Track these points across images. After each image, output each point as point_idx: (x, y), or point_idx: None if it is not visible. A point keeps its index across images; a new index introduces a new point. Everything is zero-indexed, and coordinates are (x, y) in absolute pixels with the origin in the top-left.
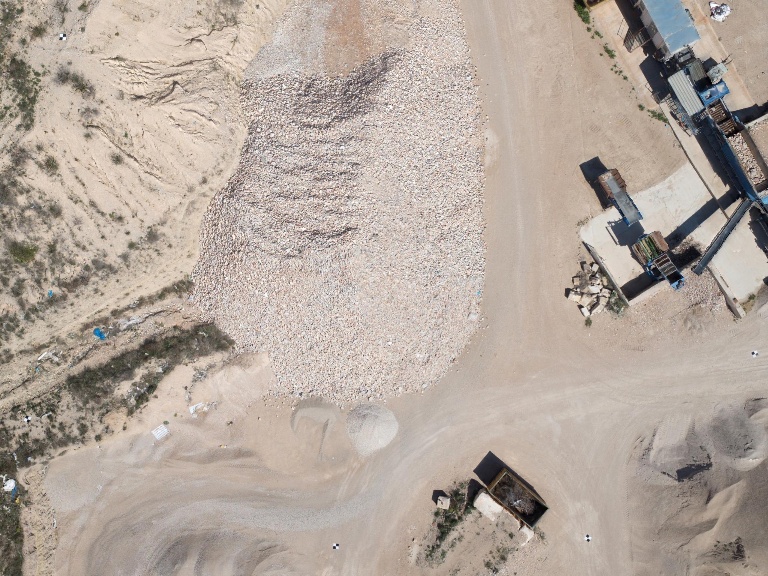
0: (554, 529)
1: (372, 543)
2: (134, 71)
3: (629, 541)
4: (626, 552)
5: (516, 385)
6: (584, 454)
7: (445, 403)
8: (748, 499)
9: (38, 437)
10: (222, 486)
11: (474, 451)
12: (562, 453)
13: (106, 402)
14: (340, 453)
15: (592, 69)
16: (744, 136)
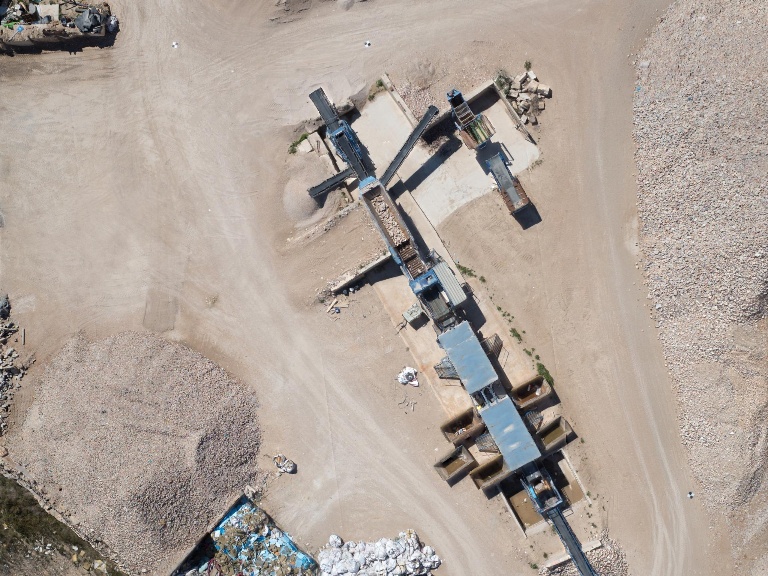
0: None
1: None
2: None
3: None
4: None
5: (597, 1)
6: None
7: None
8: None
9: None
10: None
11: None
12: None
13: None
14: None
15: (533, 318)
16: (392, 242)
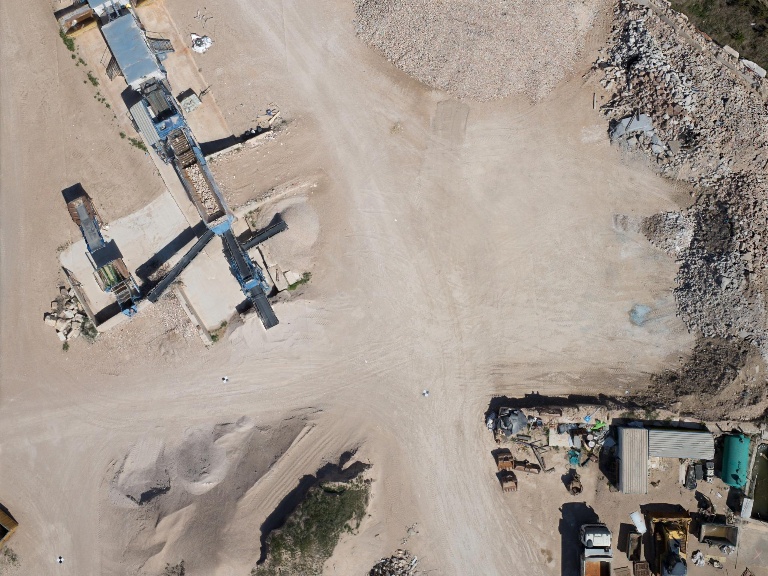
0: (27, 551)
1: None
2: None
3: (100, 563)
4: (97, 573)
5: None
6: (59, 477)
7: None
8: (194, 523)
9: None
10: None
11: None
12: (37, 476)
13: None
14: None
15: (76, 96)
16: (199, 167)
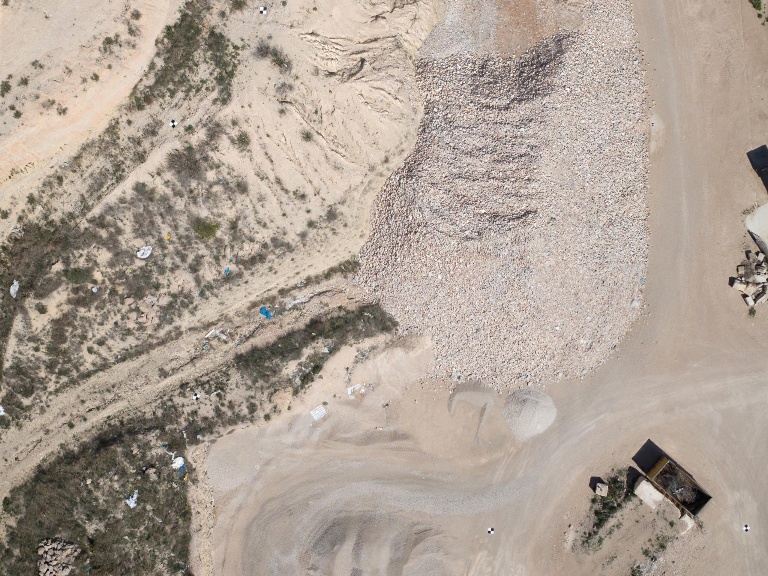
0: (712, 518)
1: (527, 528)
2: (327, 47)
3: None
4: None
5: (677, 373)
6: (744, 444)
7: (605, 390)
8: None
9: (207, 415)
10: (378, 468)
11: (633, 438)
12: (722, 442)
13: (274, 381)
14: (497, 438)
15: (762, 56)
16: None
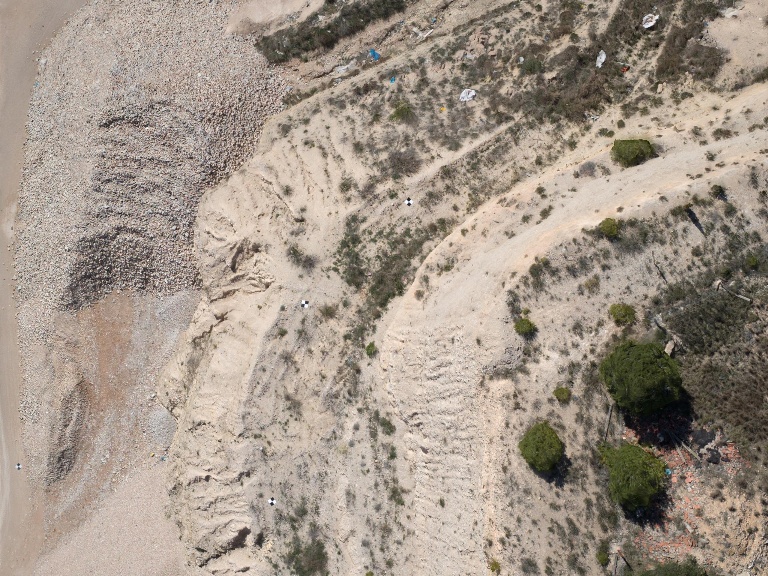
0: None
1: None
2: None
3: None
4: None
5: None
6: None
7: None
8: None
9: None
10: None
11: None
12: None
13: None
14: None
15: None
16: None
